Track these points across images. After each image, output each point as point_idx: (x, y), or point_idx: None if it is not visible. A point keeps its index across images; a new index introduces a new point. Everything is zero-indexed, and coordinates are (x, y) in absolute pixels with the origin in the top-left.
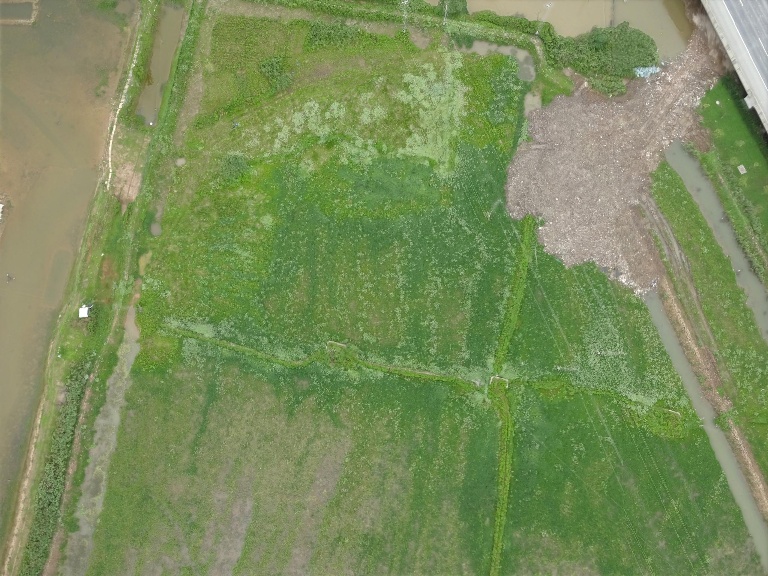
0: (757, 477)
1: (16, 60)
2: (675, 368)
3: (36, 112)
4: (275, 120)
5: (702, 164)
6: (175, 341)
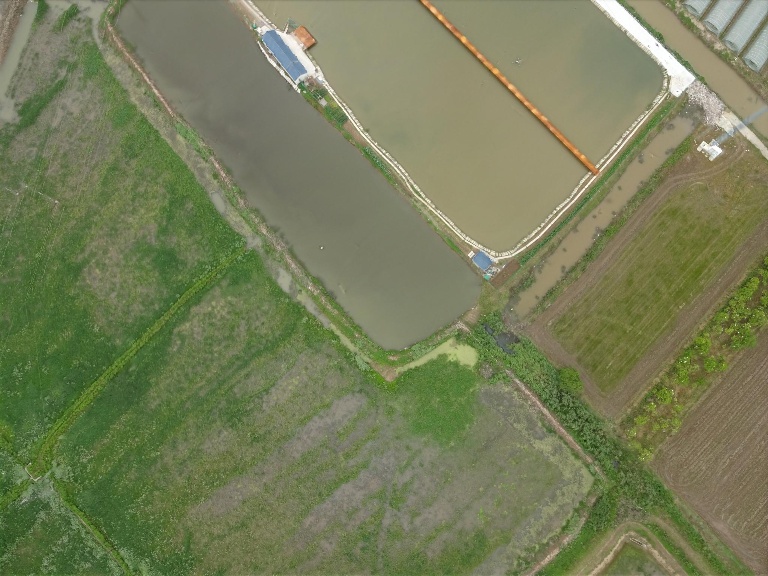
0: None
1: None
2: None
3: None
4: None
5: None
6: None
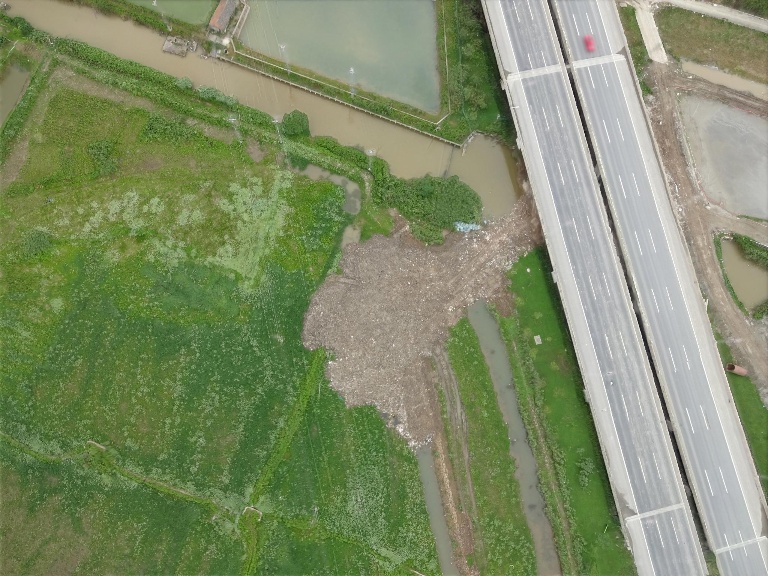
0: None
1: None
2: (432, 528)
3: None
4: (91, 203)
5: (500, 328)
6: None
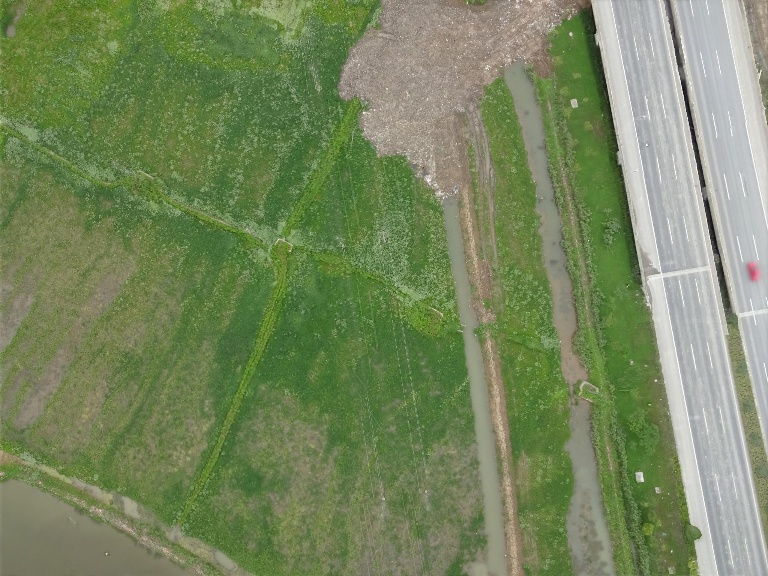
0: (497, 389)
1: None
2: (452, 273)
3: None
4: None
5: (536, 88)
6: (1, 137)
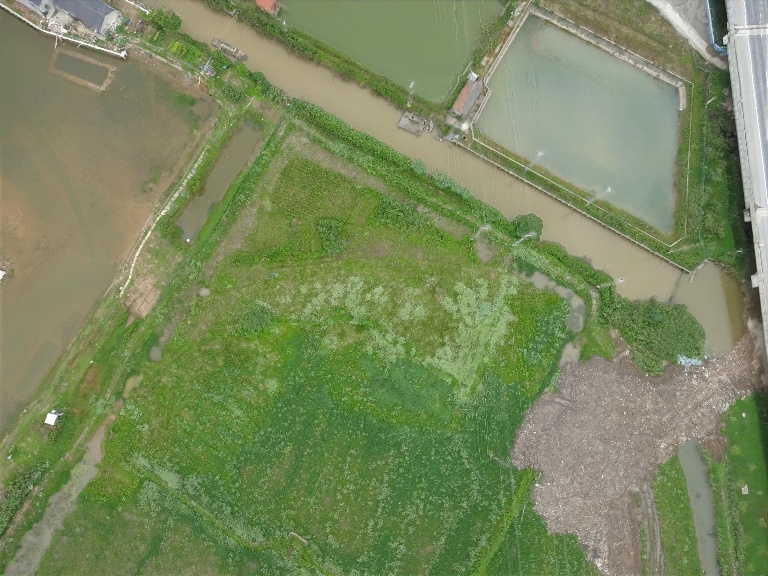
0: None
1: (72, 123)
2: None
3: (74, 185)
4: (314, 283)
5: (710, 473)
6: (136, 480)
